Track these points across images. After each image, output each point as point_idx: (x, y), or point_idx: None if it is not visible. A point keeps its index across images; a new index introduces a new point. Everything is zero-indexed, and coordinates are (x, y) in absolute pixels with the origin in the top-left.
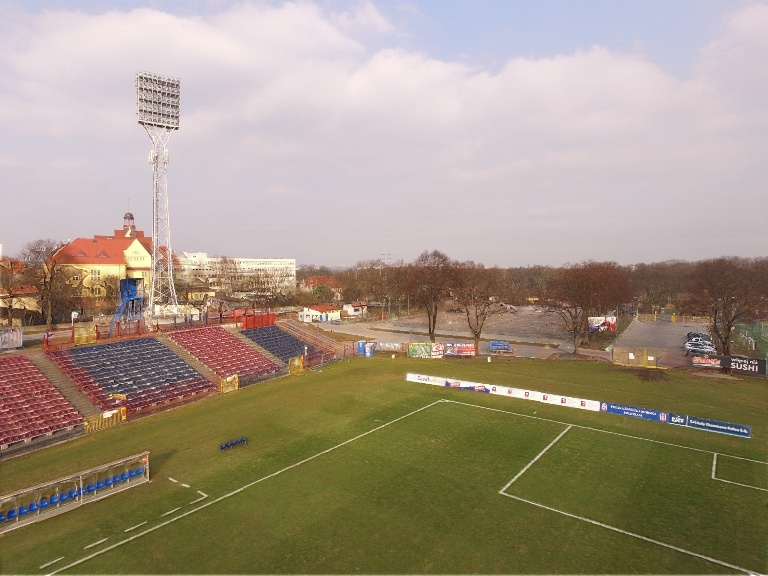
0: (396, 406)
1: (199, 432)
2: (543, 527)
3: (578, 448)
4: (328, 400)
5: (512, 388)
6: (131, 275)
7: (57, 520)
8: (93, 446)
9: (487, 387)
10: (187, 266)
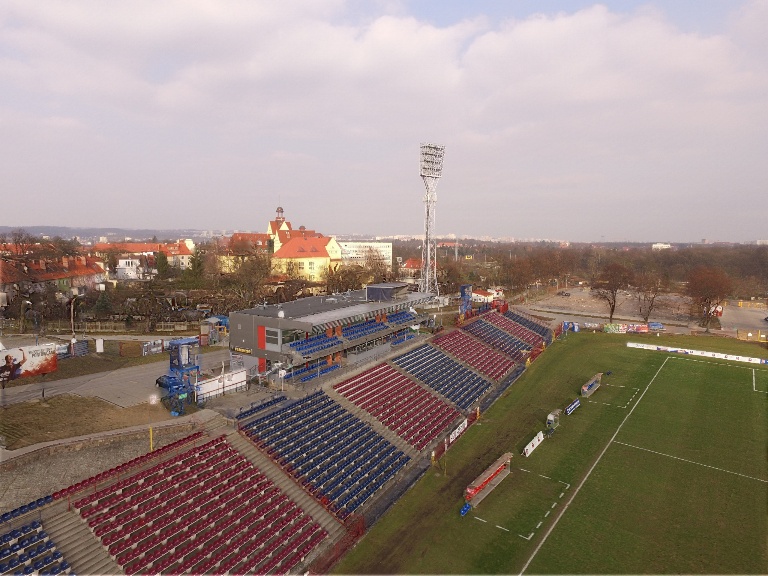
0: (650, 359)
1: None
2: None
3: None
4: (606, 356)
5: None
6: (330, 265)
7: None
8: (542, 373)
9: (687, 351)
10: (346, 254)
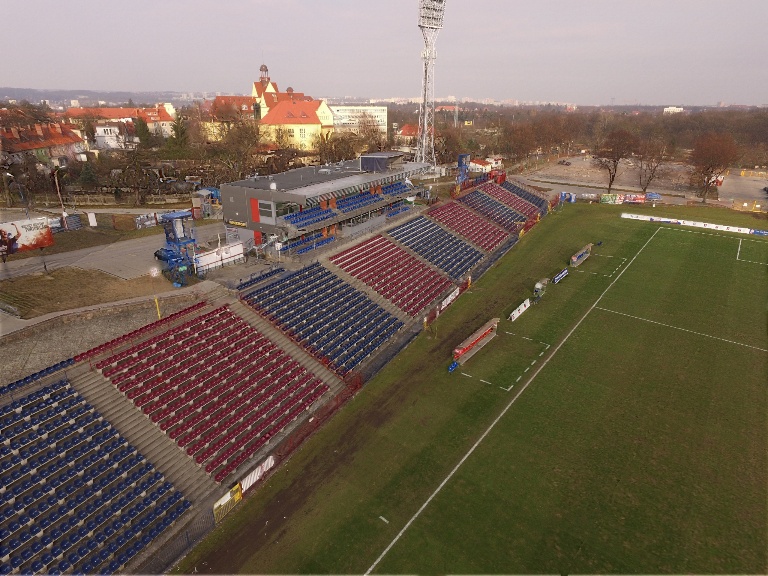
0: (642, 230)
1: (568, 239)
2: (764, 267)
3: (754, 247)
4: (599, 227)
5: (696, 222)
6: (321, 132)
7: (585, 264)
8: (534, 244)
9: (679, 221)
10: (339, 120)
